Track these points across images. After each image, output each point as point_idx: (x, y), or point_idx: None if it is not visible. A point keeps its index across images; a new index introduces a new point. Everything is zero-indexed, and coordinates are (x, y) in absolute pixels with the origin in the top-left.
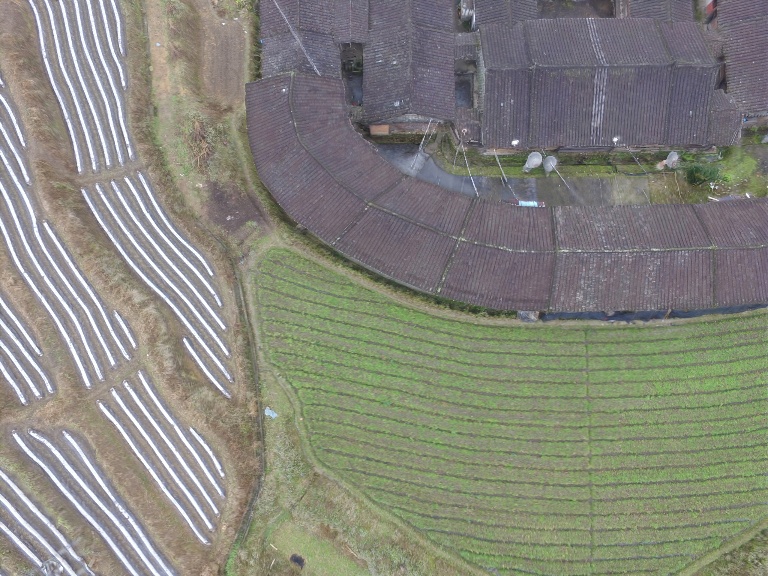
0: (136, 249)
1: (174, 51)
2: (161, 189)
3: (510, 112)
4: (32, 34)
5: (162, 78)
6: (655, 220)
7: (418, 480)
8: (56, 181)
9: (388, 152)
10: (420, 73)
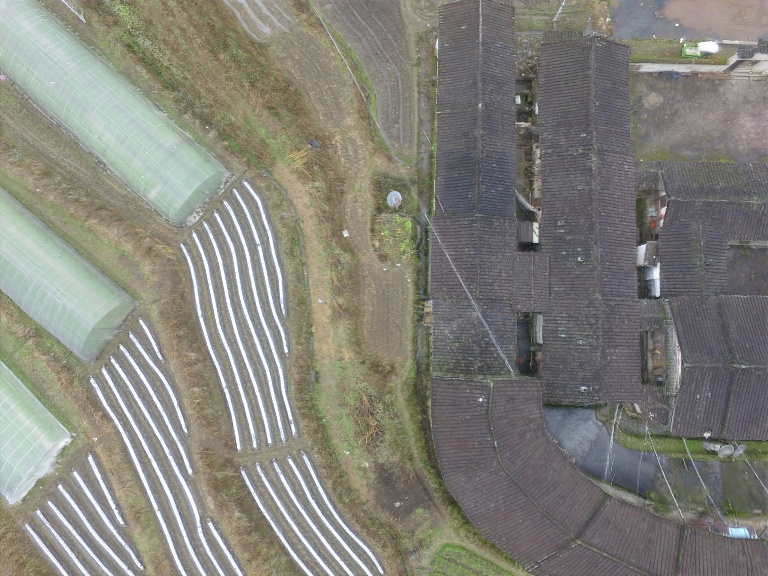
0: (301, 541)
1: (339, 311)
2: (328, 473)
3: (706, 404)
4: (186, 288)
5: (325, 340)
6: None
7: None
8: (219, 471)
9: (558, 419)
10: (609, 355)
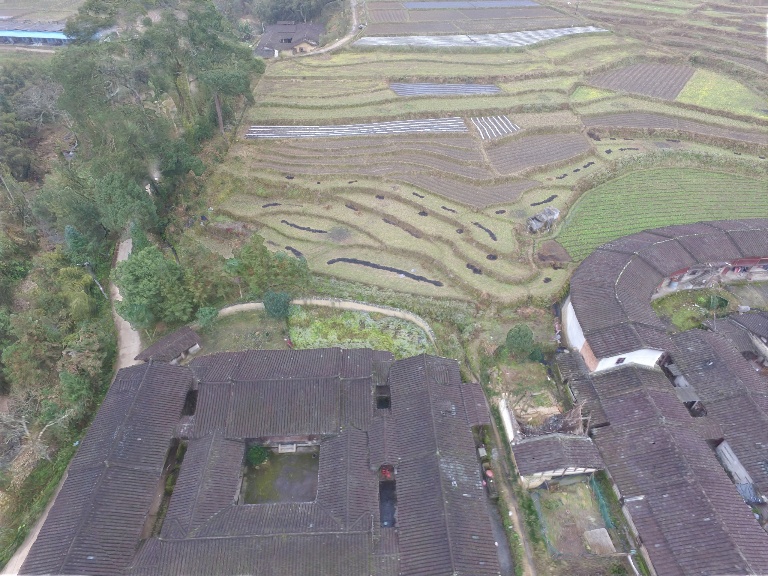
0: None
1: None
2: None
3: None
4: None
5: None
6: (763, 245)
7: (766, 190)
8: None
9: None
10: None
